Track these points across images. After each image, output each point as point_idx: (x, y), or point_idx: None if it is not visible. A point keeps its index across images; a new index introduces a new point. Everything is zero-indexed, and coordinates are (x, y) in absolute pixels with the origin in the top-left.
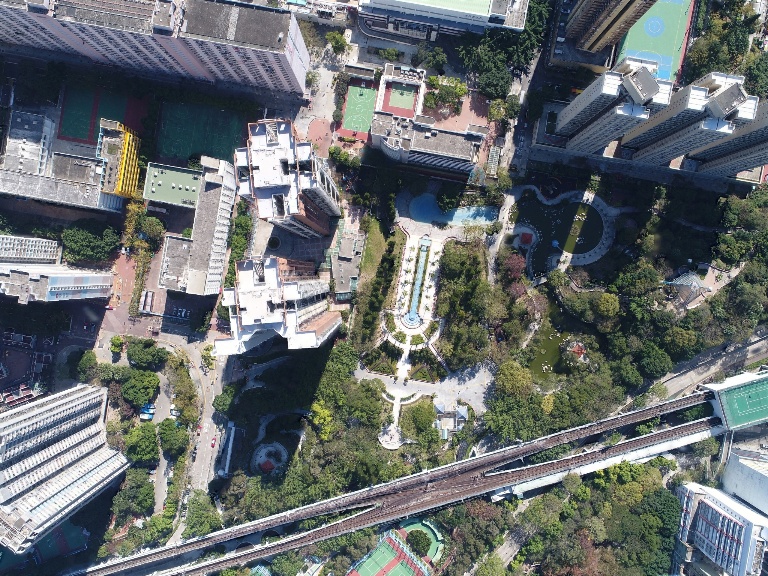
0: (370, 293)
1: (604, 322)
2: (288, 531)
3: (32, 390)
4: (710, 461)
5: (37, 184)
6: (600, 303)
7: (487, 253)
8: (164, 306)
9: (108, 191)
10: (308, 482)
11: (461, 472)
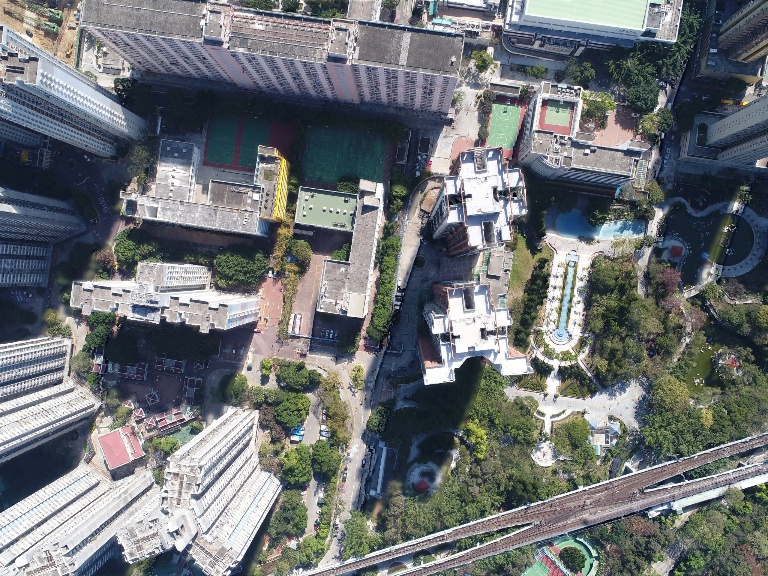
0: (522, 311)
1: (762, 334)
2: (440, 550)
3: (184, 414)
4: None
5: (196, 212)
6: (759, 315)
7: (638, 267)
8: (311, 328)
9: (266, 217)
10: (467, 501)
11: (619, 488)
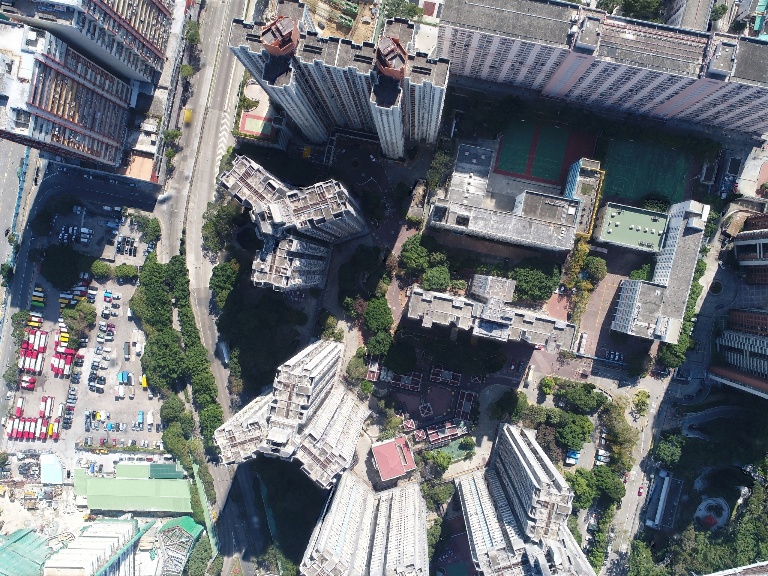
0: None
1: None
2: None
3: (457, 429)
4: None
5: (510, 223)
6: None
7: None
8: (595, 348)
9: (583, 233)
10: (766, 541)
11: None
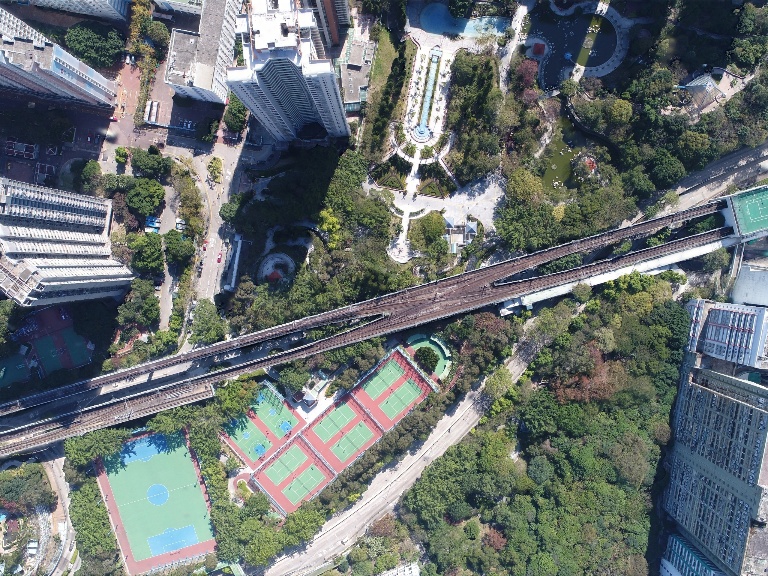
0: (380, 100)
1: (617, 129)
2: None
3: None
4: (720, 279)
5: None
6: (613, 108)
7: (499, 62)
8: (169, 118)
9: None
10: (316, 288)
11: (470, 282)
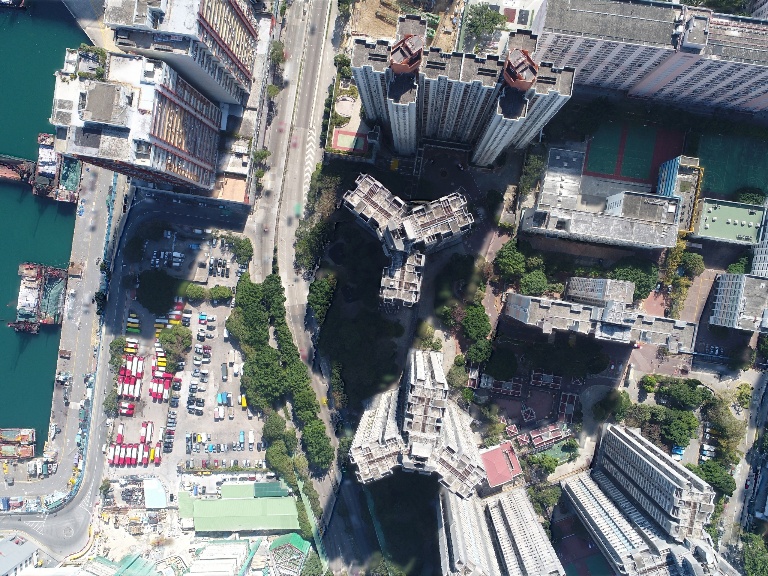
0: None
1: None
2: None
3: (560, 431)
4: None
5: (611, 224)
6: None
7: None
8: (694, 344)
9: (685, 230)
10: None
11: None
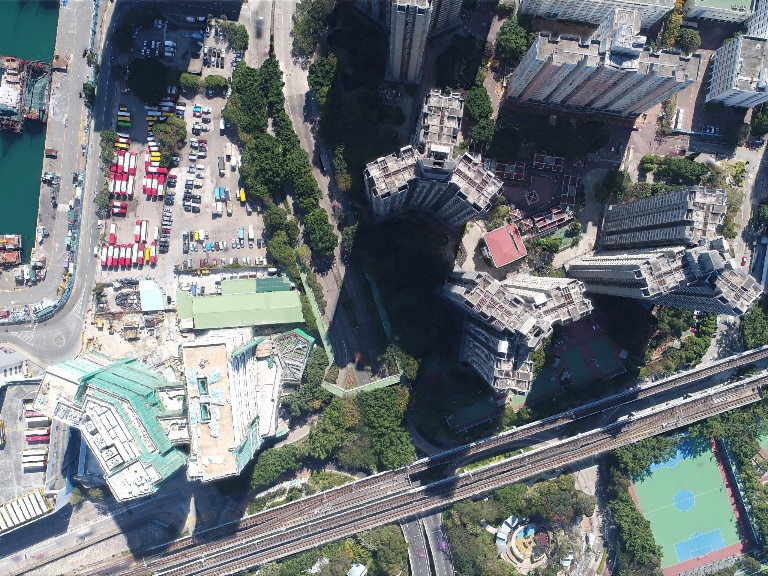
0: None
1: None
2: None
3: (563, 214)
4: None
5: None
6: None
7: None
8: (690, 124)
9: None
10: None
11: None
